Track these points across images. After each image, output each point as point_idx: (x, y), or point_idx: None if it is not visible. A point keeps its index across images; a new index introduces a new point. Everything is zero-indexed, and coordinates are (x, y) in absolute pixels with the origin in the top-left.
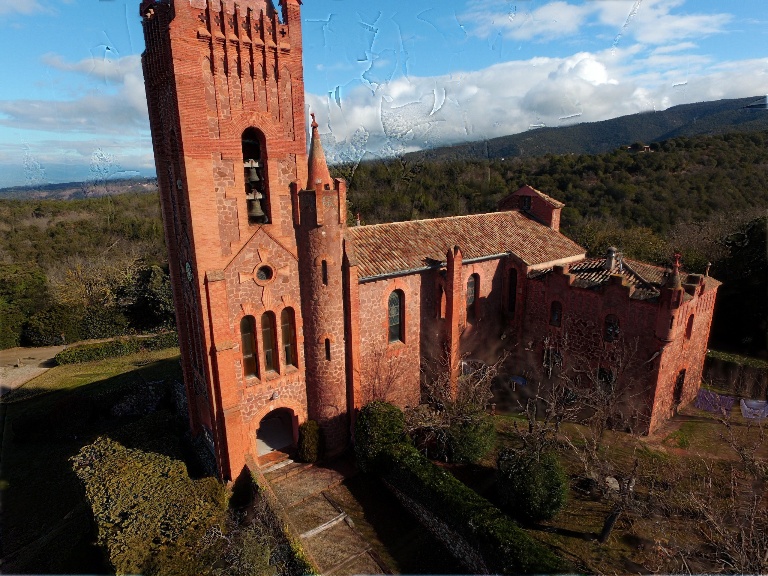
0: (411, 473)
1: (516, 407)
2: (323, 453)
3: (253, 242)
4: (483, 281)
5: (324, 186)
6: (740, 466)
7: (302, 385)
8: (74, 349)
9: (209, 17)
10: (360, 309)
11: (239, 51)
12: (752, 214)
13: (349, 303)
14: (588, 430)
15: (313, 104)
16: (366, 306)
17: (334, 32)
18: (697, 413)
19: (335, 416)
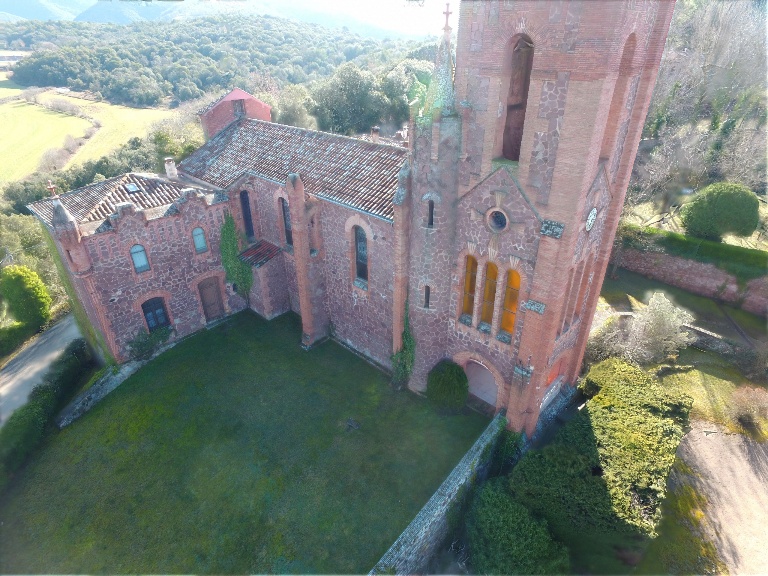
0: None
1: None
2: None
3: None
4: None
5: None
6: None
7: None
8: None
9: None
10: None
11: None
12: (211, 99)
13: None
14: None
15: None
16: None
17: None
18: None
19: None
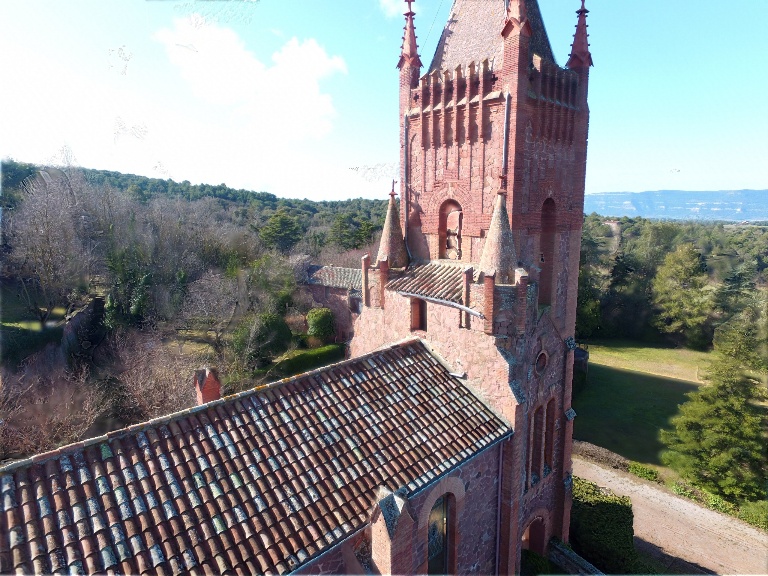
0: None
1: None
2: None
3: None
4: None
5: None
6: None
7: None
8: None
9: None
10: None
11: None
12: None
13: None
14: None
15: None
16: None
17: None
18: None
19: None
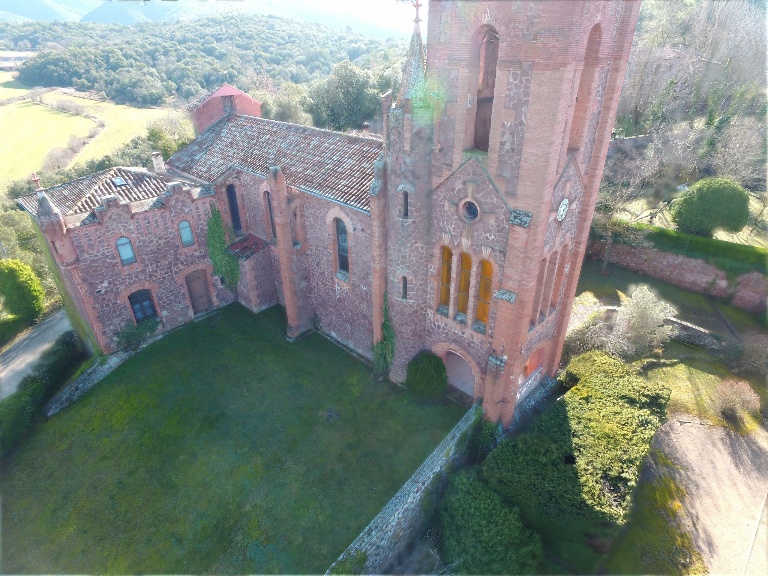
0: None
1: None
2: None
3: None
4: None
5: None
6: None
7: None
8: None
9: None
10: None
11: None
12: None
13: None
14: None
15: None
16: None
17: None
18: None
19: None
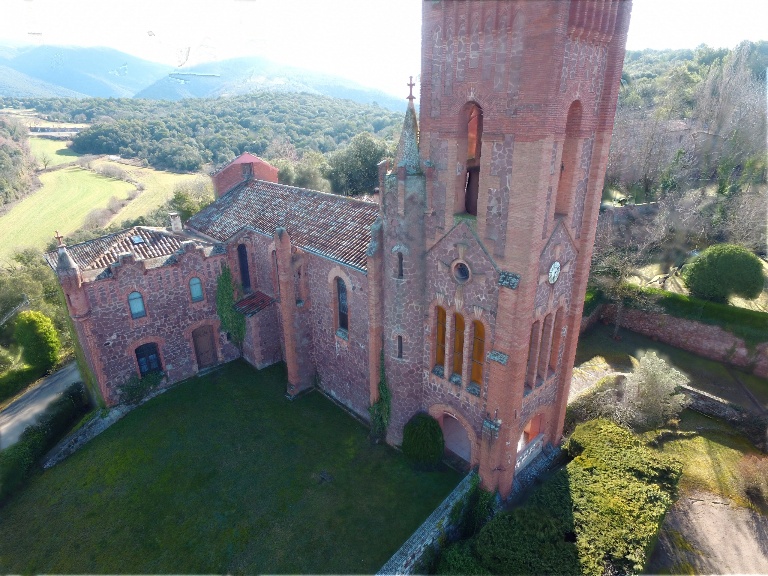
0: None
1: None
2: None
3: None
4: None
5: None
6: None
7: None
8: None
9: None
10: None
11: None
12: None
13: None
14: None
15: None
16: None
17: None
18: None
19: None
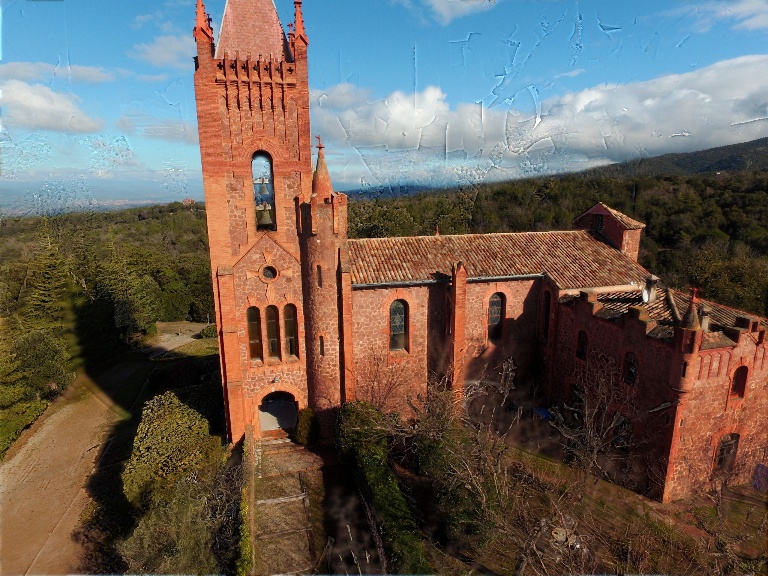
0: (364, 472)
1: (525, 439)
2: (315, 439)
3: (259, 245)
4: (511, 301)
5: (324, 200)
6: (765, 567)
7: (303, 375)
8: (214, 327)
9: (225, 65)
10: (358, 313)
11: (250, 89)
12: None
13: (342, 306)
14: (590, 479)
15: (451, 121)
16: (364, 311)
17: (473, 51)
18: (757, 494)
19: (328, 408)
